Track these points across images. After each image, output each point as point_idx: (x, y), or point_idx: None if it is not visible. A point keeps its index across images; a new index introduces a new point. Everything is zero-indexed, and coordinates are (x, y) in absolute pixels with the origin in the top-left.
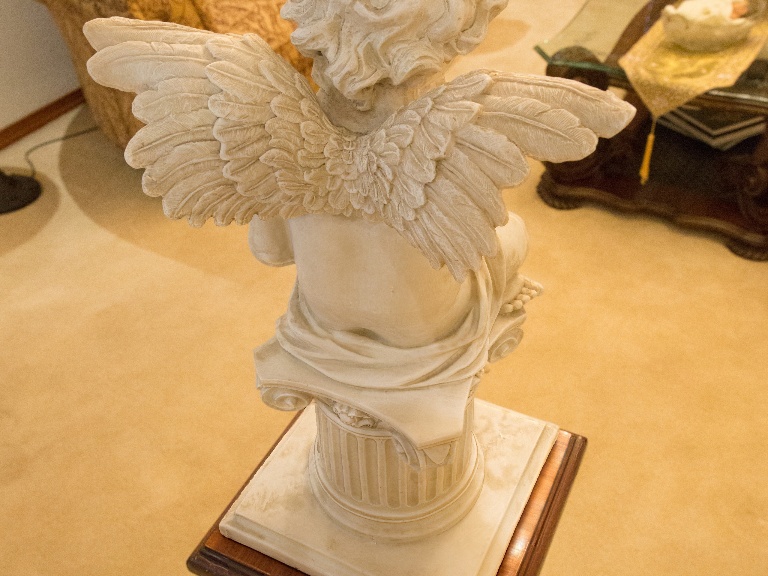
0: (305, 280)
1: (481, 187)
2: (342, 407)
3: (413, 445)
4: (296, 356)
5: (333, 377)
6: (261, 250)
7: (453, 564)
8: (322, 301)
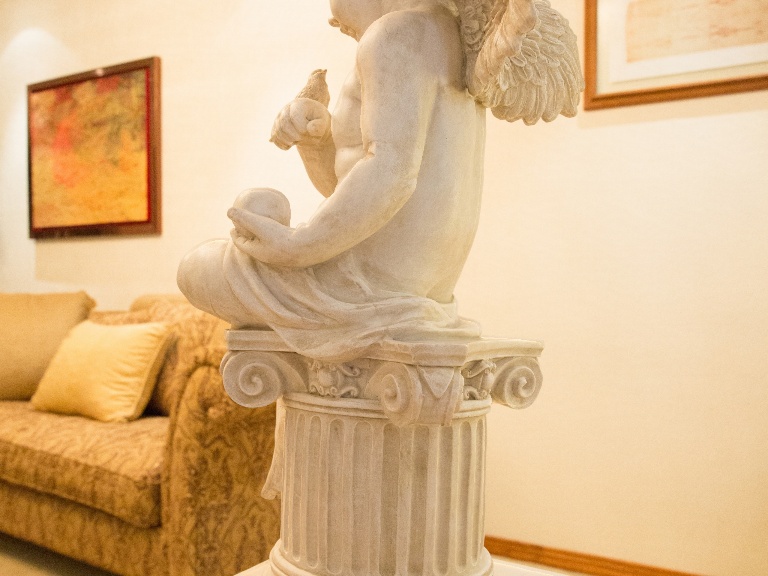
0: (455, 194)
1: (574, 39)
2: (488, 363)
3: (535, 356)
4: (438, 330)
5: (471, 331)
6: (414, 173)
7: (523, 575)
8: (459, 223)
